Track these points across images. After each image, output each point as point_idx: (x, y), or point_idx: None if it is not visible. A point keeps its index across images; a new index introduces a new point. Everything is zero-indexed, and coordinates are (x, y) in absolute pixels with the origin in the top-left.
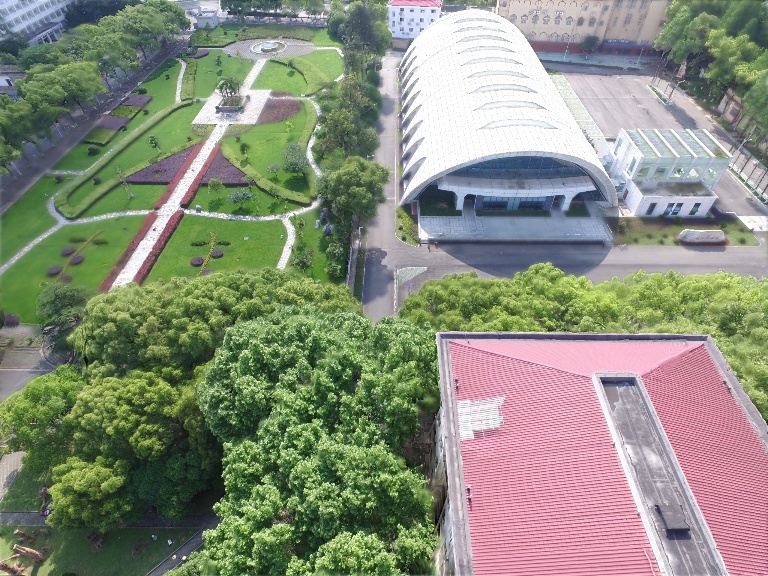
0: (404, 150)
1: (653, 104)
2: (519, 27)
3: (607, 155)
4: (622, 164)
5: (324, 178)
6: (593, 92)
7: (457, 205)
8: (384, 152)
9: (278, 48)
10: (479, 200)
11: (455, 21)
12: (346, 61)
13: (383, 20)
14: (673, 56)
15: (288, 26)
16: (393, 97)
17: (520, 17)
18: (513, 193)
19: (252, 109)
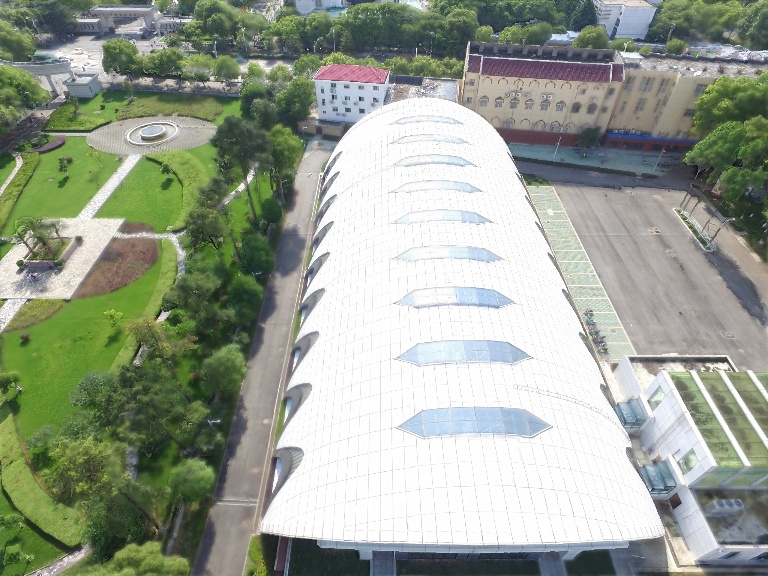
0: (290, 379)
1: (687, 248)
2: (492, 112)
3: (635, 399)
4: (666, 439)
5: (92, 517)
6: (597, 222)
7: (360, 555)
8: (264, 366)
9: (165, 134)
10: (401, 552)
11: (396, 120)
12: (189, 228)
13: (308, 98)
14: (720, 187)
15: (191, 96)
16: (304, 232)
17: (493, 100)
18: (466, 550)
19: (78, 263)
